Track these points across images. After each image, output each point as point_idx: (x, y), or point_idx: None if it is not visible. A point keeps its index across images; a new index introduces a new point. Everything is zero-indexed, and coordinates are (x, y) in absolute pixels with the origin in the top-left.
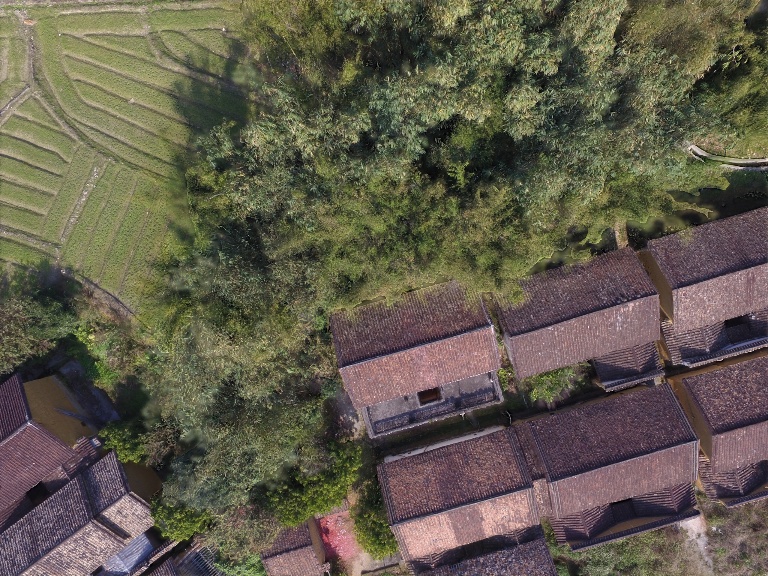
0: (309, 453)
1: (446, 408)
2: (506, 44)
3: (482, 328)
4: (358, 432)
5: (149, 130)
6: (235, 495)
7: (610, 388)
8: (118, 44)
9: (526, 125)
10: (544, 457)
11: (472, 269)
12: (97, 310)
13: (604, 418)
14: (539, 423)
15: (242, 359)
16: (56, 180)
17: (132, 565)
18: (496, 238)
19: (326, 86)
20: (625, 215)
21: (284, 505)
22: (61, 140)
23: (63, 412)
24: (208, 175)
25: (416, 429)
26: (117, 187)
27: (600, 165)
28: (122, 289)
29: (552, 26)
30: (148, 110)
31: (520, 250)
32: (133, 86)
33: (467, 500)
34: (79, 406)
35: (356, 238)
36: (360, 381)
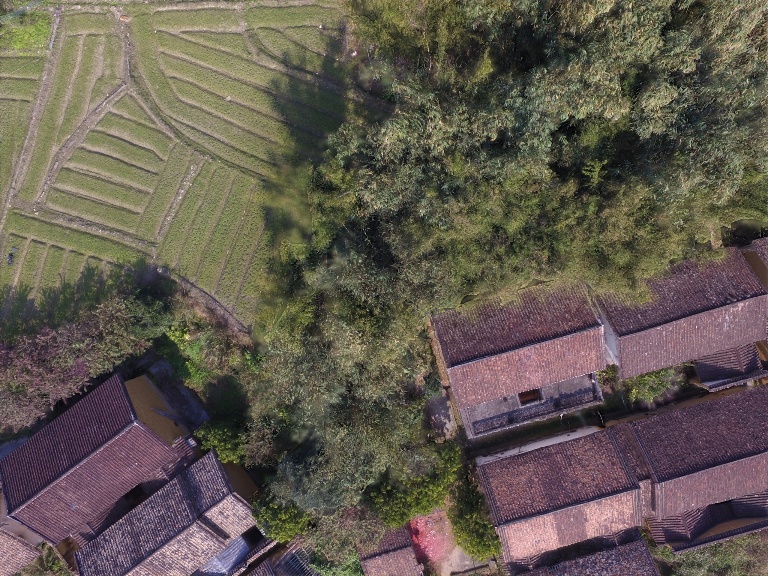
0: (412, 453)
1: (545, 408)
2: (644, 41)
3: (592, 328)
4: (450, 432)
5: (246, 128)
6: (348, 496)
7: (714, 388)
8: (215, 41)
9: (658, 123)
10: (649, 458)
11: (601, 268)
12: (192, 309)
13: (707, 419)
14: (641, 424)
15: (372, 359)
16: (152, 178)
17: (230, 566)
18: (630, 237)
19: (458, 83)
20: (747, 214)
21: (390, 506)
22: (157, 138)
23: (158, 412)
24: (336, 173)
25: (508, 429)
26: (214, 185)
27: (739, 164)
28: (219, 288)
29: (681, 23)
30: (245, 108)
31: (657, 249)
32: (230, 83)
33: (573, 501)
34: (169, 406)
35: (480, 237)
36: (467, 381)
